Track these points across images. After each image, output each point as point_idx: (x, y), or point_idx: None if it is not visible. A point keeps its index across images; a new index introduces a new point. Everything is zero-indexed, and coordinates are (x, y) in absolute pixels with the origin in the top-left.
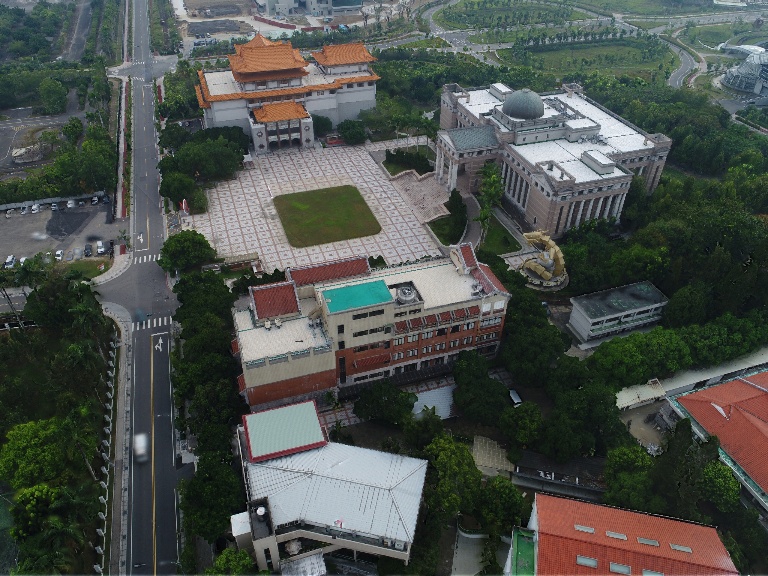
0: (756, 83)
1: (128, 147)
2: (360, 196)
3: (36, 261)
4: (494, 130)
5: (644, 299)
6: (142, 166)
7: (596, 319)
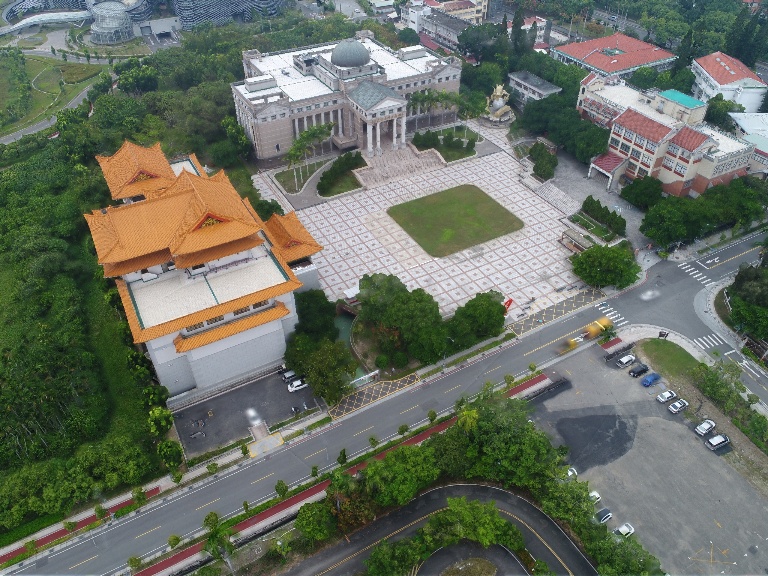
0: (133, 29)
1: (345, 455)
2: (409, 202)
3: (715, 380)
4: (371, 81)
5: (527, 76)
6: (385, 427)
7: (559, 88)
